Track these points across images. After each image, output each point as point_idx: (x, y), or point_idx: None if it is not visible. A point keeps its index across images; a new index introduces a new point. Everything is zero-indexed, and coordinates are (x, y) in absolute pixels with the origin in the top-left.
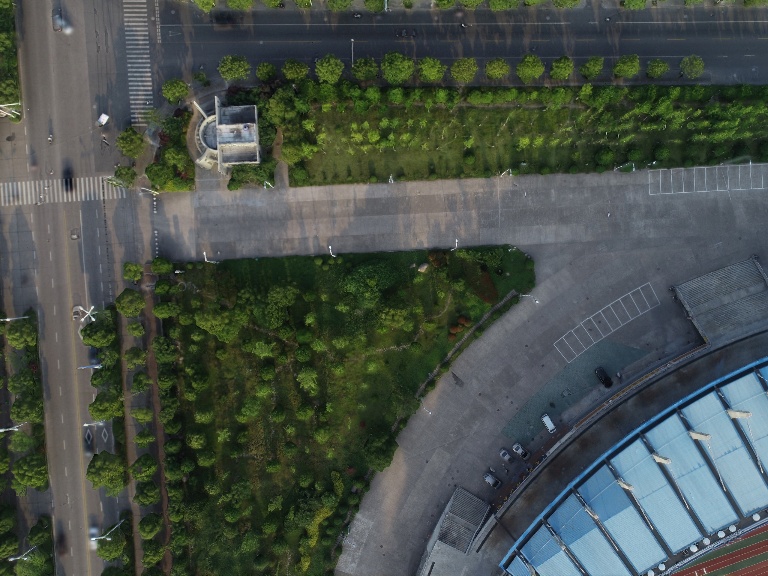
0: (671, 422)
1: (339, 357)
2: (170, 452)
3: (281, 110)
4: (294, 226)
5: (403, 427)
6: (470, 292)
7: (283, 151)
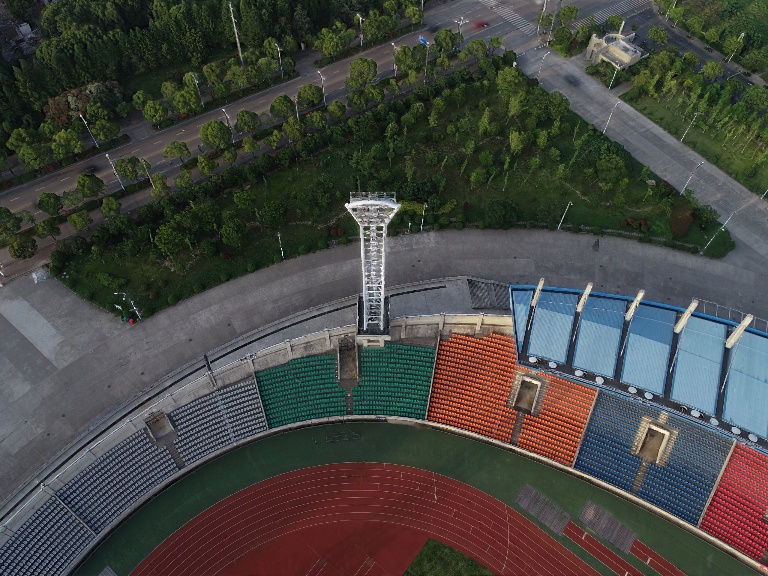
0: (767, 342)
1: (541, 165)
2: (396, 103)
3: (664, 59)
4: (598, 109)
5: (530, 223)
6: (671, 209)
7: (641, 72)
